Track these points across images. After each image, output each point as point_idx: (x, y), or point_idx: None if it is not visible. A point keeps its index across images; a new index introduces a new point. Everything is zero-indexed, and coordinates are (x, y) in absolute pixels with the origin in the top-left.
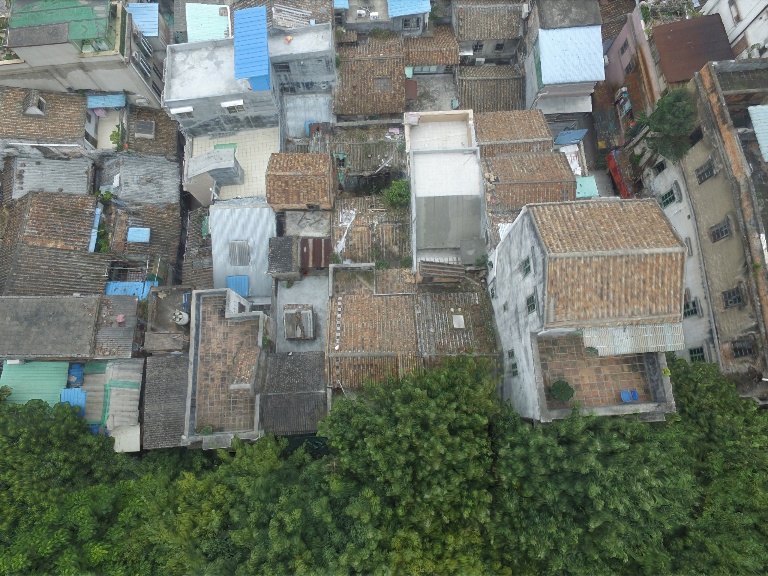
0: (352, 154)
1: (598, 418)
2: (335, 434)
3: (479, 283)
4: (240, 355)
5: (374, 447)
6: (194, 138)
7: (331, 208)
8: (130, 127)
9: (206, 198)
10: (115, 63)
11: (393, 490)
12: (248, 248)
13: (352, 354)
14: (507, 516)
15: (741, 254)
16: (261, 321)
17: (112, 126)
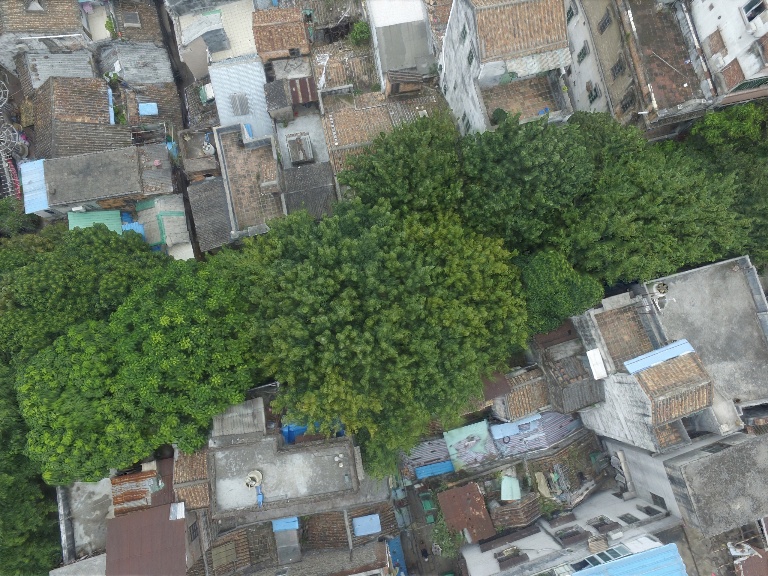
0: (316, 10)
1: (524, 125)
2: (350, 178)
3: (434, 89)
4: (263, 166)
5: (380, 167)
6: (179, 17)
7: (309, 52)
8: (118, 19)
9: (199, 69)
10: None
11: (398, 193)
12: (246, 99)
13: (349, 146)
14: (475, 202)
15: (618, 32)
16: (273, 141)
17: (101, 21)
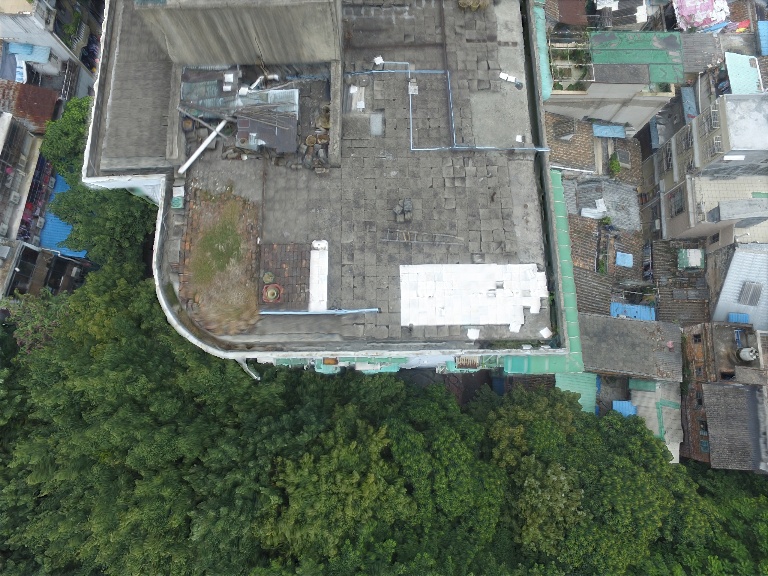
0: None
1: None
2: None
3: None
4: None
5: None
6: (695, 177)
7: None
8: None
9: (691, 233)
10: (658, 102)
11: None
12: None
13: None
14: None
15: None
16: None
17: None
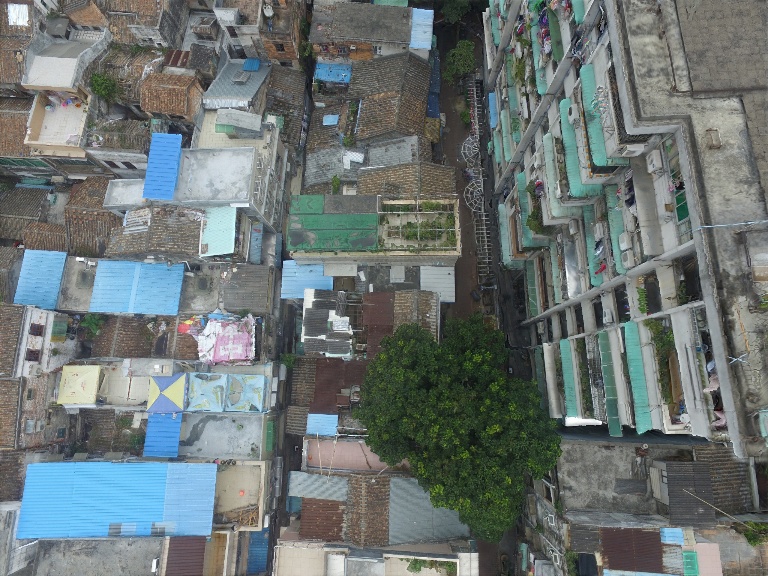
0: None
1: None
2: None
3: None
4: None
5: None
6: None
7: None
8: None
9: None
10: None
11: None
12: None
13: None
14: None
15: None
16: (214, 3)
17: None
